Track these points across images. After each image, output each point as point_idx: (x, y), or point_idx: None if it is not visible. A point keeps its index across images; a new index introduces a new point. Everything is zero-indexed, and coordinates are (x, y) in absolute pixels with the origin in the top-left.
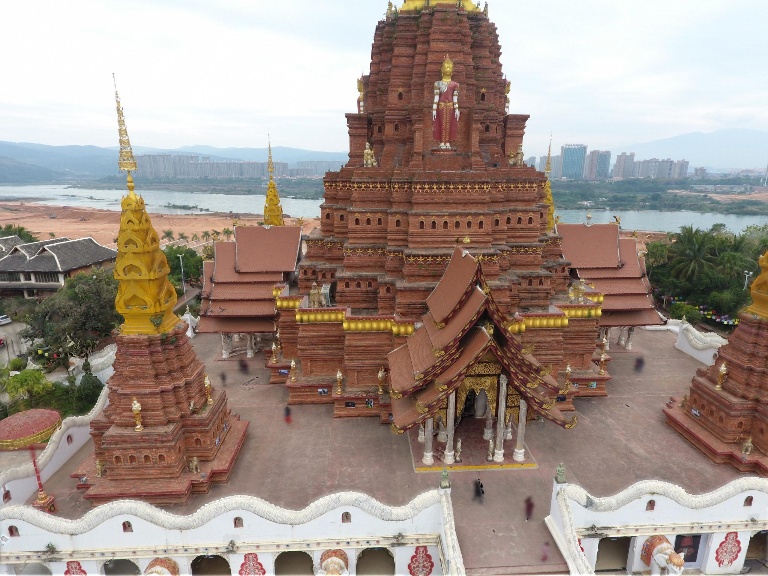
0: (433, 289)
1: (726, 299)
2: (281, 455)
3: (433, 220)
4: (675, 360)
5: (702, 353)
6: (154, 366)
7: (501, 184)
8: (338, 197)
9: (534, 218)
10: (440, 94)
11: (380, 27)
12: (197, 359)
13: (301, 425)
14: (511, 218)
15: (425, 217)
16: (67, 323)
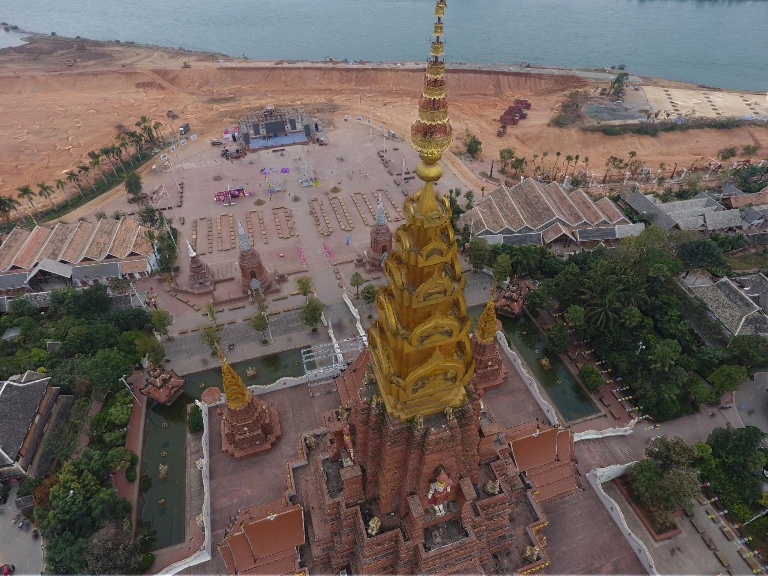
0: None
1: (623, 368)
2: None
3: (435, 572)
4: (586, 504)
5: (604, 499)
6: None
7: None
8: None
9: None
10: None
11: (365, 407)
12: None
13: None
14: None
15: None
16: None
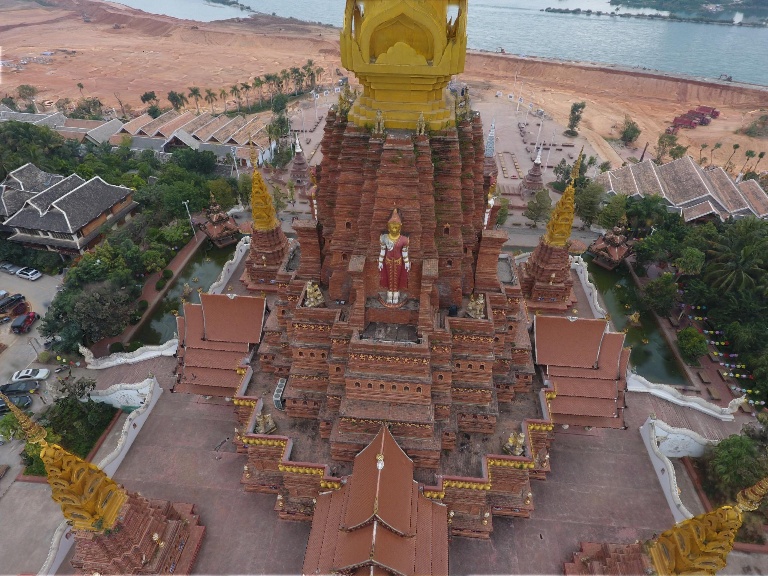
0: (363, 446)
1: (743, 339)
2: (226, 569)
3: (369, 382)
4: (626, 457)
5: (655, 458)
6: (105, 546)
7: (448, 347)
8: (289, 308)
9: (486, 366)
10: (386, 249)
11: (330, 121)
12: (148, 510)
13: (250, 525)
14: (461, 364)
15: (361, 379)
16: (76, 332)
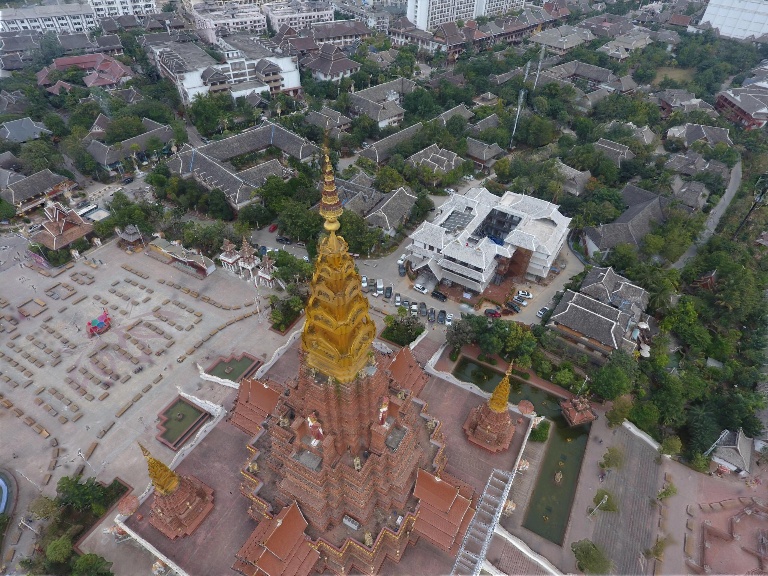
0: None
1: None
2: None
3: None
4: None
5: None
6: None
7: None
8: None
9: None
10: None
11: None
12: None
13: None
14: None
15: None
16: None
